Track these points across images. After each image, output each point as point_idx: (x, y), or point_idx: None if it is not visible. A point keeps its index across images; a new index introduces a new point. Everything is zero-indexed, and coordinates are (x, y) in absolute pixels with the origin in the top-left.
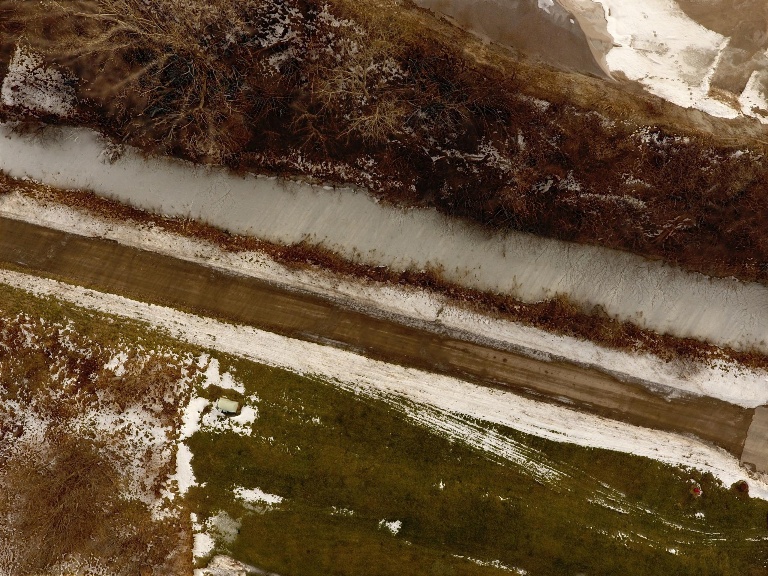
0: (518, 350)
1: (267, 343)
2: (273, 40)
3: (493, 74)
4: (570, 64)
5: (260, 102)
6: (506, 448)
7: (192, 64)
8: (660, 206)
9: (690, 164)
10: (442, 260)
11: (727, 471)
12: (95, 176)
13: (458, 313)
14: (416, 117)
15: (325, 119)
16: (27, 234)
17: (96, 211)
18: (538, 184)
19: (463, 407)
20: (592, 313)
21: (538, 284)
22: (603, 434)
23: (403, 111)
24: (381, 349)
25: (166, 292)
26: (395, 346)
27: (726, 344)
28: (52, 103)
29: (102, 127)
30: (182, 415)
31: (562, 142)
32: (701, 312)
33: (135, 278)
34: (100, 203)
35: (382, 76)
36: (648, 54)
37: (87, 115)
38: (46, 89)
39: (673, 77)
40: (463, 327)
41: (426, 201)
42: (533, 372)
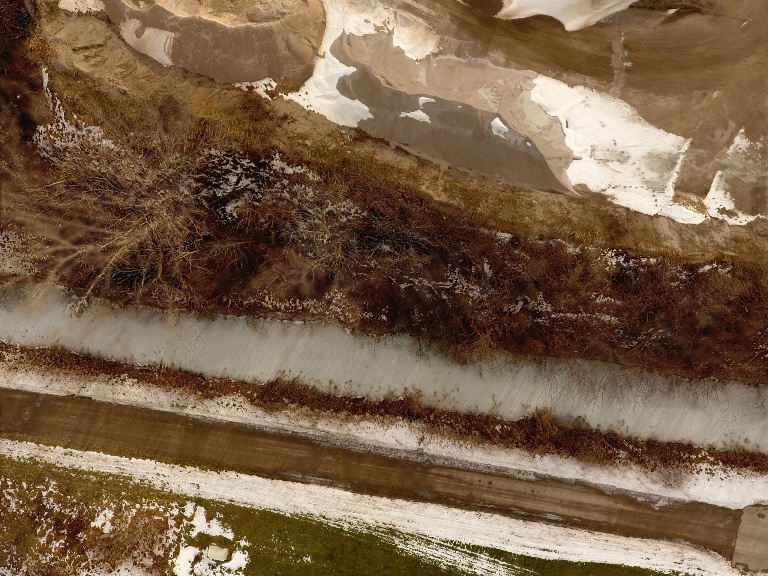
0: (502, 472)
1: (251, 487)
2: (228, 188)
3: (452, 211)
4: (531, 182)
5: (221, 252)
6: (498, 571)
7: (149, 215)
8: (632, 321)
9: (659, 281)
10: (419, 385)
11: (720, 574)
12: (63, 331)
13: (439, 440)
14: (380, 251)
15: (288, 260)
16: (1, 398)
17: (67, 369)
18: (509, 306)
19: (452, 534)
20: (574, 426)
21: (517, 401)
22: (594, 548)
23: (366, 246)
24: (366, 482)
25: (146, 444)
26: (379, 478)
27: (710, 445)
28: (12, 264)
29: (65, 281)
30: (173, 567)
31: (528, 268)
32: (683, 415)
33: (113, 433)
34: (71, 359)
35: (341, 215)
36: (609, 164)
37: (49, 271)
38: (4, 251)
39: (636, 185)
40: (446, 454)
41: (398, 328)
42: (519, 492)
